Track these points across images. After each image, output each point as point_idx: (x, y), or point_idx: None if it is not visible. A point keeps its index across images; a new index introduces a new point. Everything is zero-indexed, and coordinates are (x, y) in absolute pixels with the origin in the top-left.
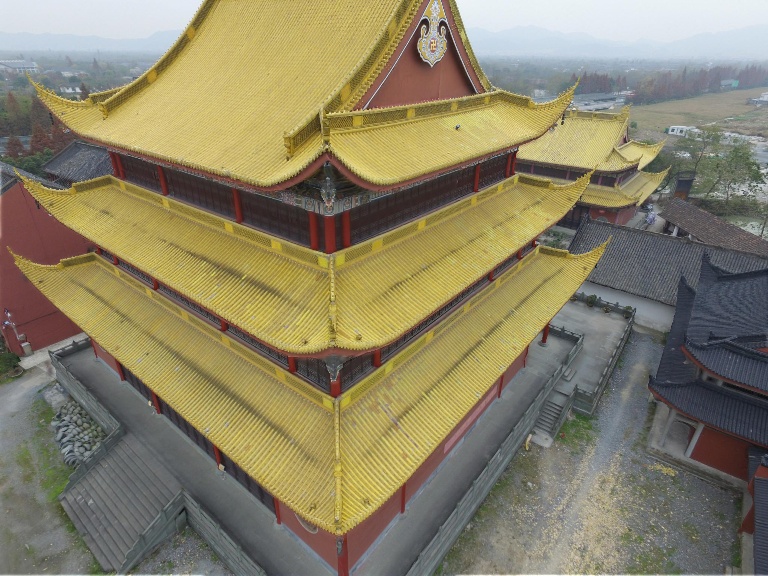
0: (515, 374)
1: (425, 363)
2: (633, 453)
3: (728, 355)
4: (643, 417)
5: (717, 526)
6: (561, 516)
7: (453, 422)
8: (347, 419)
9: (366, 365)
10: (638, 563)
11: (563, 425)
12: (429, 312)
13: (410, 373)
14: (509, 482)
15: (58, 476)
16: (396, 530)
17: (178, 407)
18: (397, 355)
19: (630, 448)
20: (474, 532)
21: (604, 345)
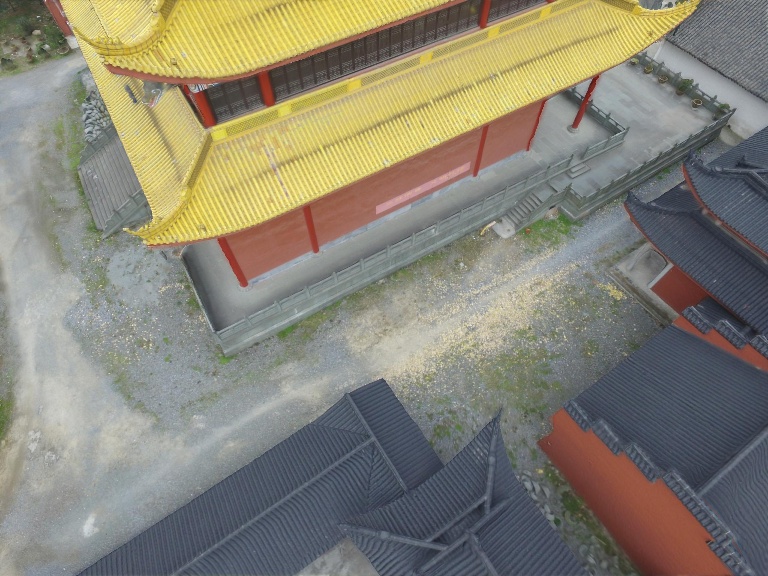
0: (509, 156)
1: (339, 115)
2: (593, 268)
3: (743, 191)
4: (637, 237)
5: (623, 353)
6: (472, 298)
7: (339, 183)
8: (221, 153)
9: (253, 101)
10: (515, 354)
11: (537, 222)
12: (304, 50)
13: (315, 122)
14: (442, 257)
15: (79, 150)
16: (305, 264)
17: (109, 108)
18: (297, 98)
19: (594, 262)
20: (383, 287)
21: (653, 147)
